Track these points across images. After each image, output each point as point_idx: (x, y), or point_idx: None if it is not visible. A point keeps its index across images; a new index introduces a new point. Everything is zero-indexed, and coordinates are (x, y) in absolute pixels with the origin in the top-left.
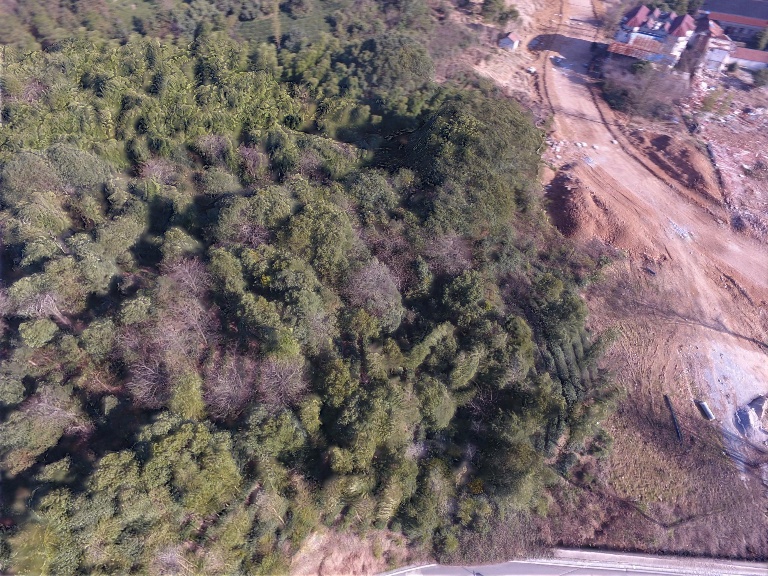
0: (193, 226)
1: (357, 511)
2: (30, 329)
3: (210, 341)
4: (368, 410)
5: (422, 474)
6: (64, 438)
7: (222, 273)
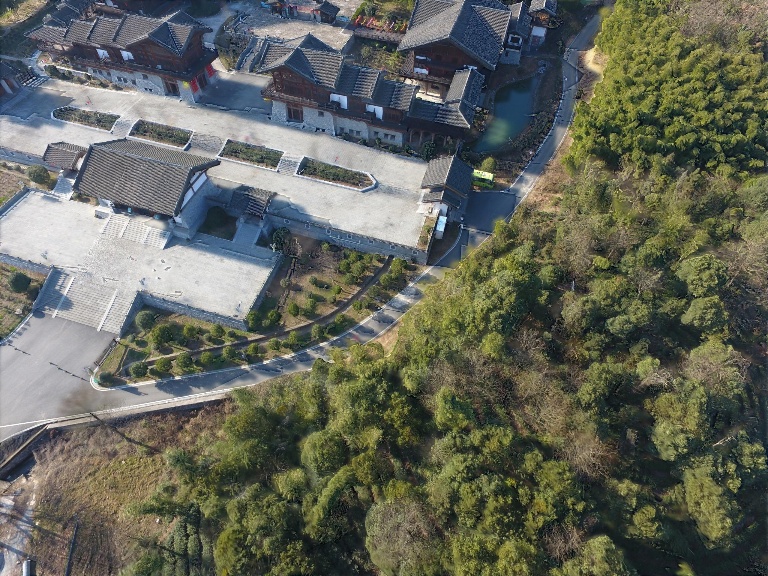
0: None
1: None
2: (651, 363)
3: None
4: None
5: (324, 406)
6: None
7: None
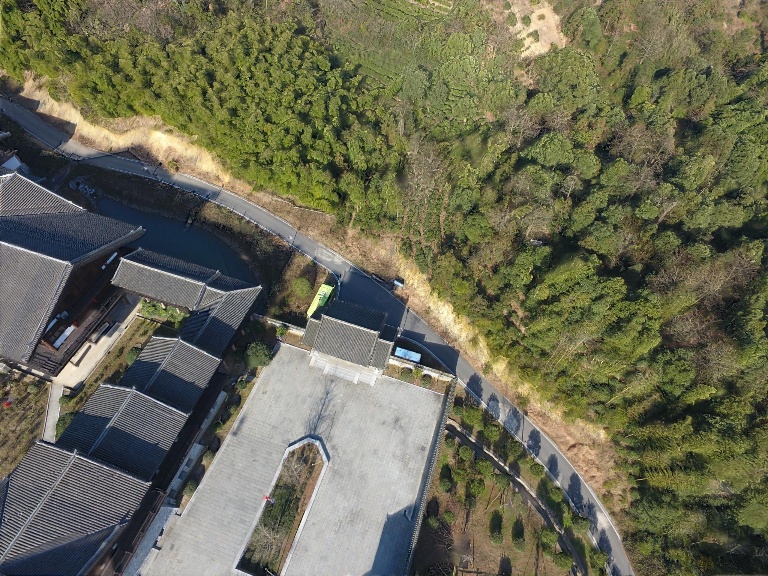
0: (764, 256)
1: (649, 450)
2: (649, 206)
3: (695, 306)
4: (729, 436)
5: None
6: (600, 255)
7: (762, 289)
